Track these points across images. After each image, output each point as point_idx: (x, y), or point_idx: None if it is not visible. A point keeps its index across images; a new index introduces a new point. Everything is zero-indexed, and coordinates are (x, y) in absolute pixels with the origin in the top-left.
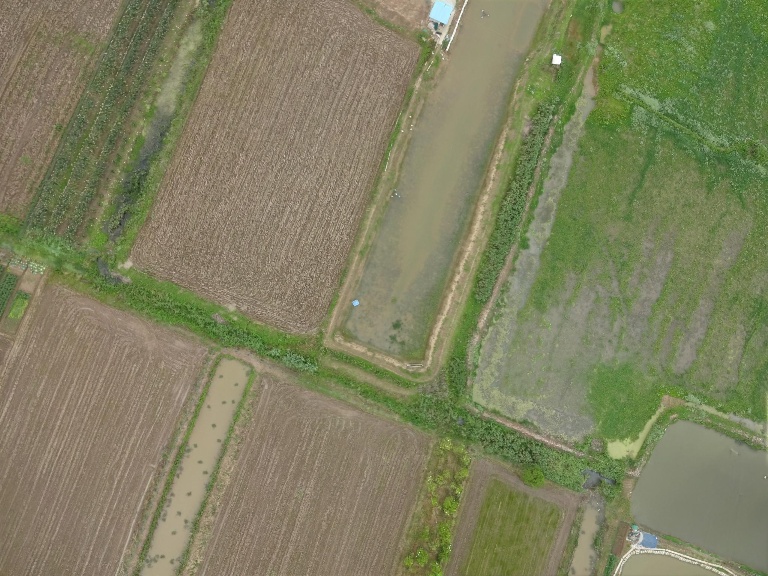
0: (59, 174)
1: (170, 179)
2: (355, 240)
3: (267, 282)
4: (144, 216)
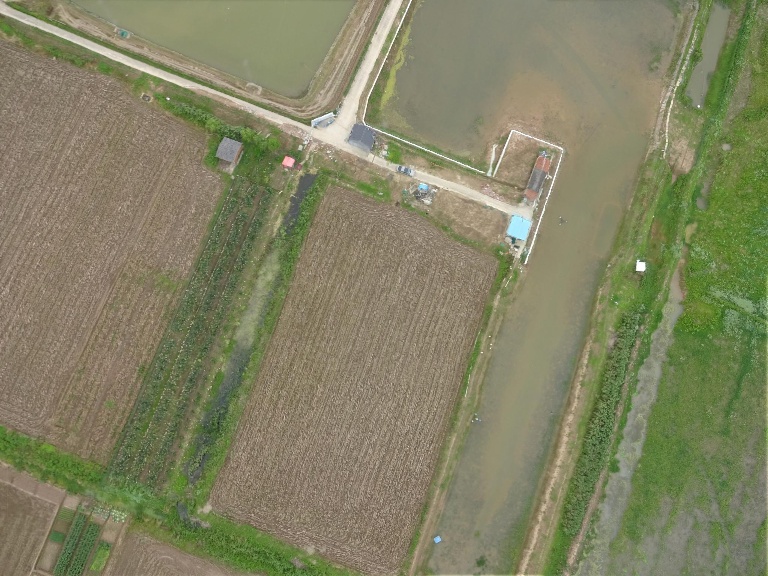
0: (141, 417)
1: (249, 416)
2: (435, 471)
3: (346, 521)
4: (223, 457)
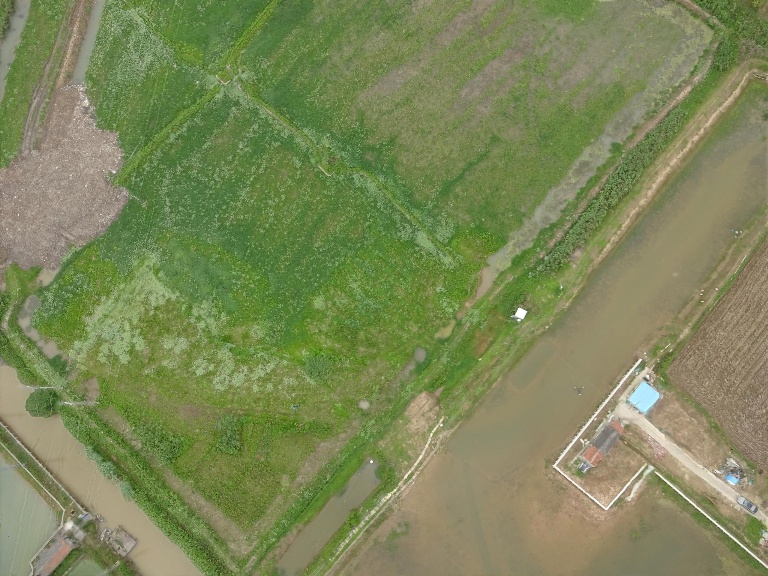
0: None
1: None
2: None
3: None
4: None
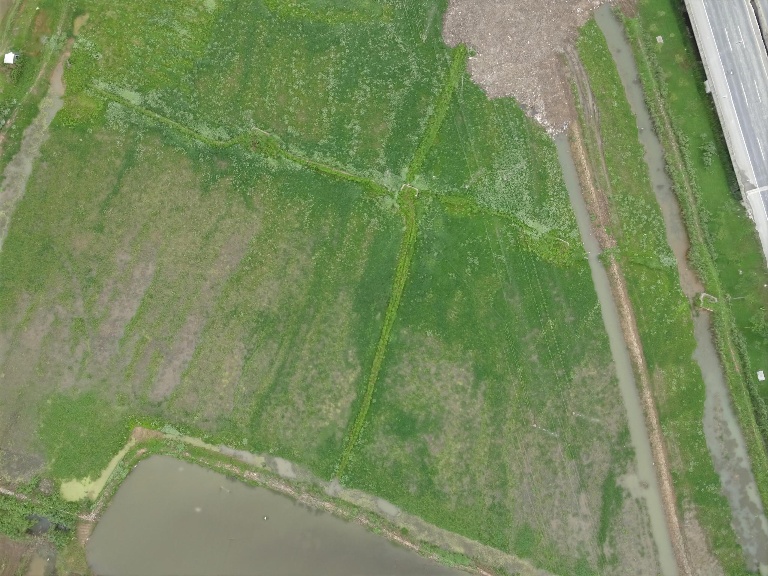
0: None
1: None
2: None
3: None
4: None
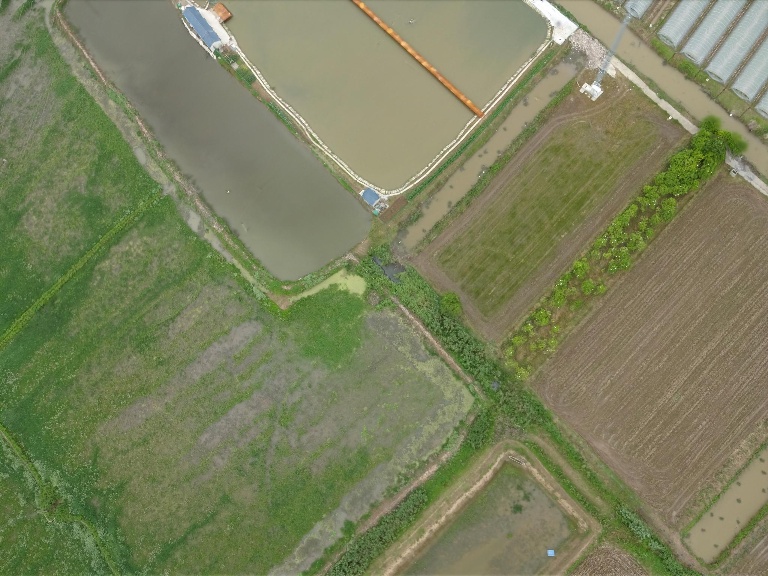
0: None
1: None
2: None
3: None
4: None
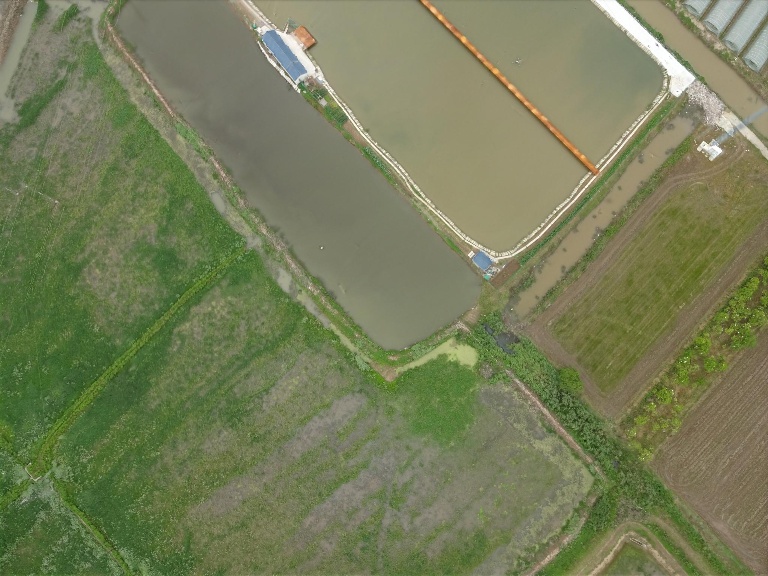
0: None
1: None
2: None
3: None
4: None
